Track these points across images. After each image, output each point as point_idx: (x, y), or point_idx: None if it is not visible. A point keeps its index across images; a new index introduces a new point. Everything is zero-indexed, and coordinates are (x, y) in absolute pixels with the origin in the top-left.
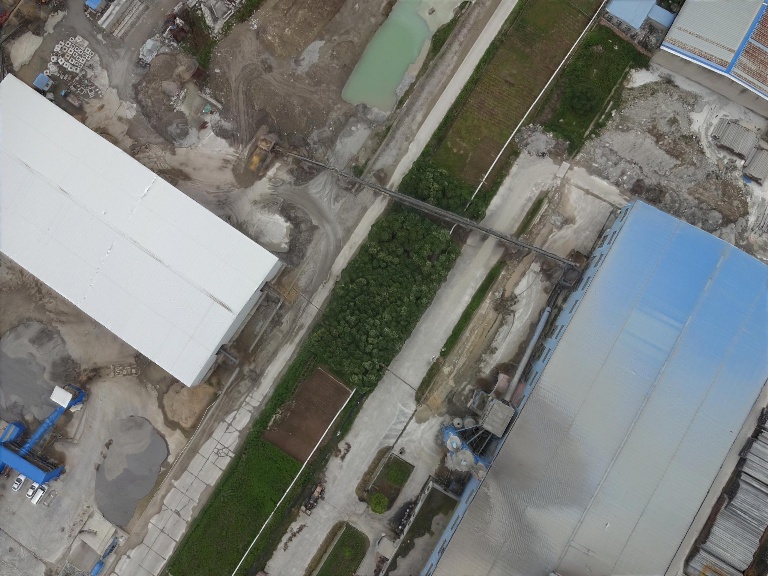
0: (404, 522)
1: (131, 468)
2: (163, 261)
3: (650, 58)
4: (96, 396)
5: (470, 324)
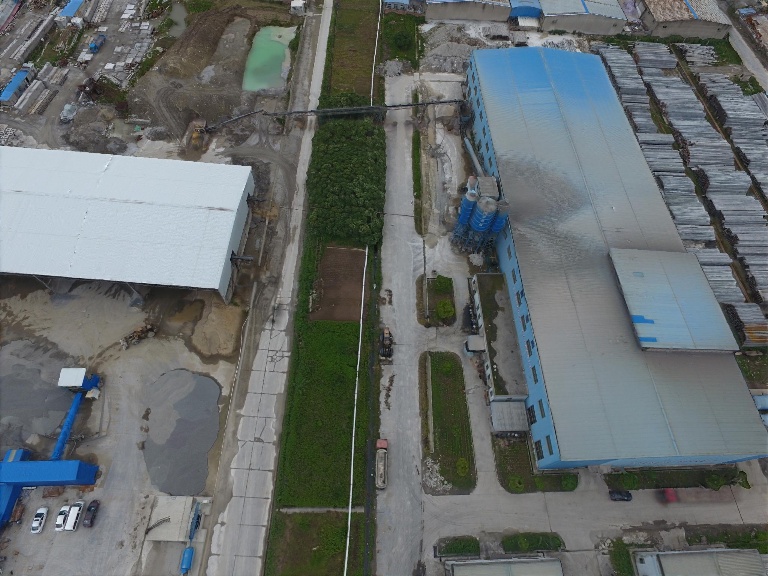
0: (474, 321)
1: (185, 416)
2: (145, 202)
3: (424, 17)
4: (113, 376)
5: (422, 172)
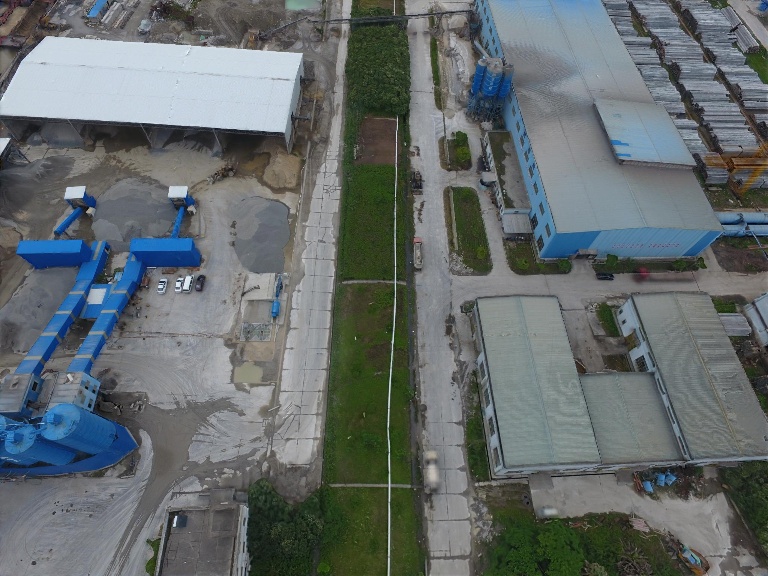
0: (487, 166)
1: (264, 222)
2: (222, 74)
3: None
4: (205, 201)
5: (439, 67)
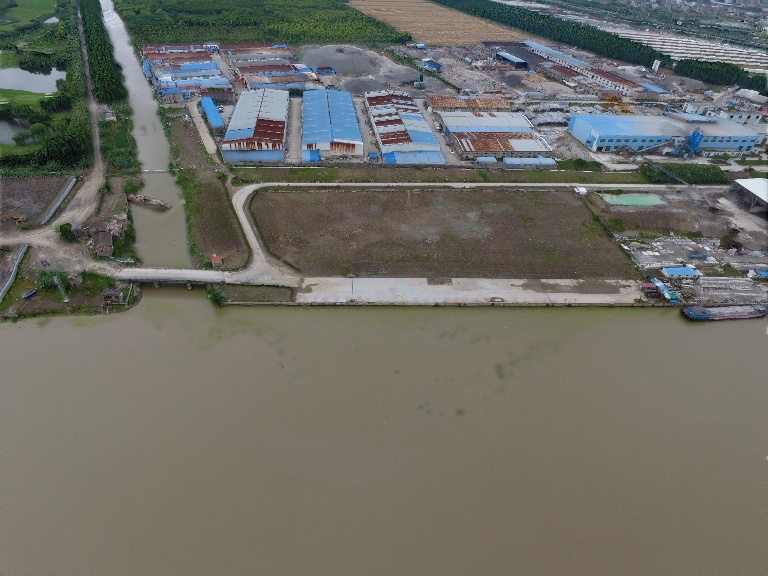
0: None
1: None
2: None
3: None
4: None
5: None
